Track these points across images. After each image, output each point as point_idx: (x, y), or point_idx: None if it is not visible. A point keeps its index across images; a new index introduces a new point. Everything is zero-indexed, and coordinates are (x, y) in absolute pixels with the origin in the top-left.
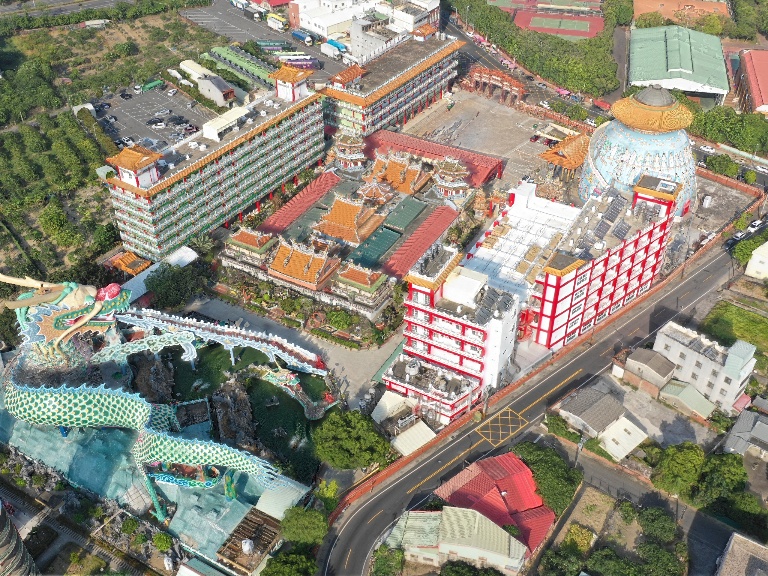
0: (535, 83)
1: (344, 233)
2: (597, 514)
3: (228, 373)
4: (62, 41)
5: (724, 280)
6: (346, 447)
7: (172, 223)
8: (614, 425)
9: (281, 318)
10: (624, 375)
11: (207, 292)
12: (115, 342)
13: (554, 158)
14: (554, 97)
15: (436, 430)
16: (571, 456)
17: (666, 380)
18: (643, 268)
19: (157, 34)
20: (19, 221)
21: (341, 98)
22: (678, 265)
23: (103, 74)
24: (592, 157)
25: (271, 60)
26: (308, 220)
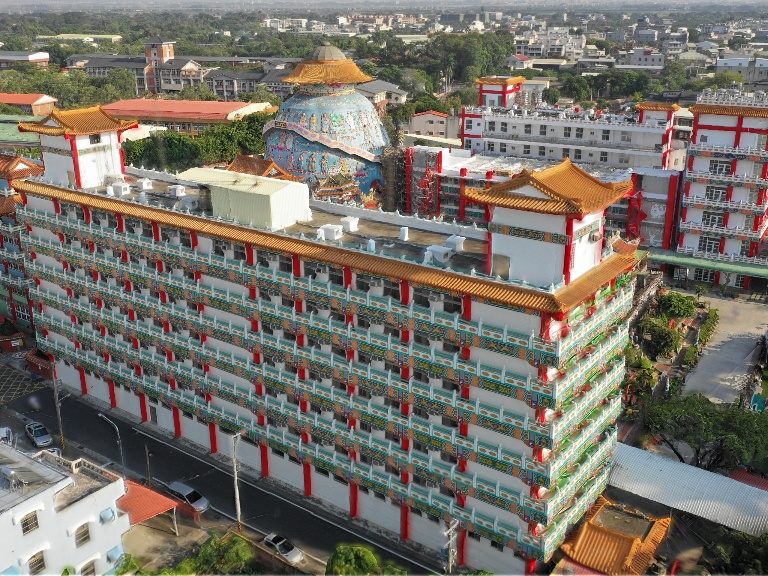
0: None
1: None
2: None
3: None
4: None
5: None
6: None
7: None
8: None
9: (678, 368)
10: None
11: (643, 443)
12: None
13: None
14: None
15: None
16: None
17: None
18: None
19: None
20: None
21: None
22: None
23: None
24: None
25: None
26: None
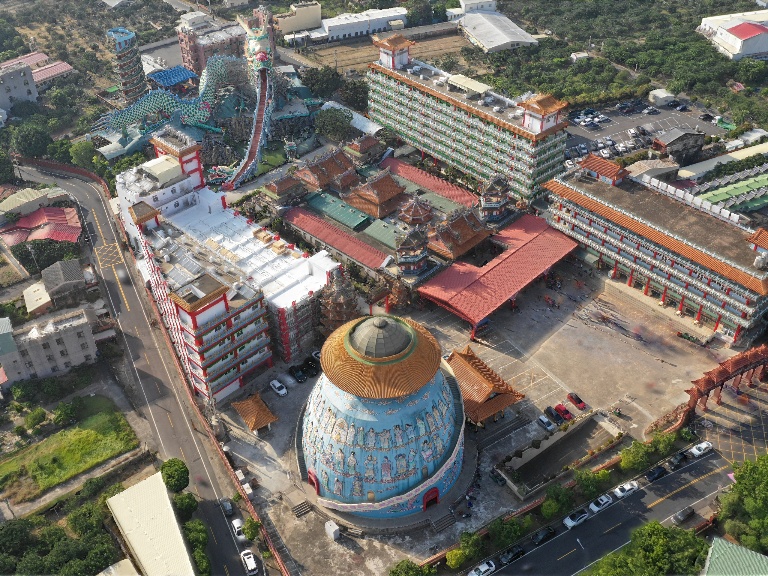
0: None
1: None
2: (3, 275)
3: None
4: None
5: None
6: None
7: None
8: None
9: None
10: None
11: None
12: None
13: None
14: None
15: None
16: None
17: None
18: None
19: None
20: None
21: None
22: None
23: None
24: None
25: None
26: None
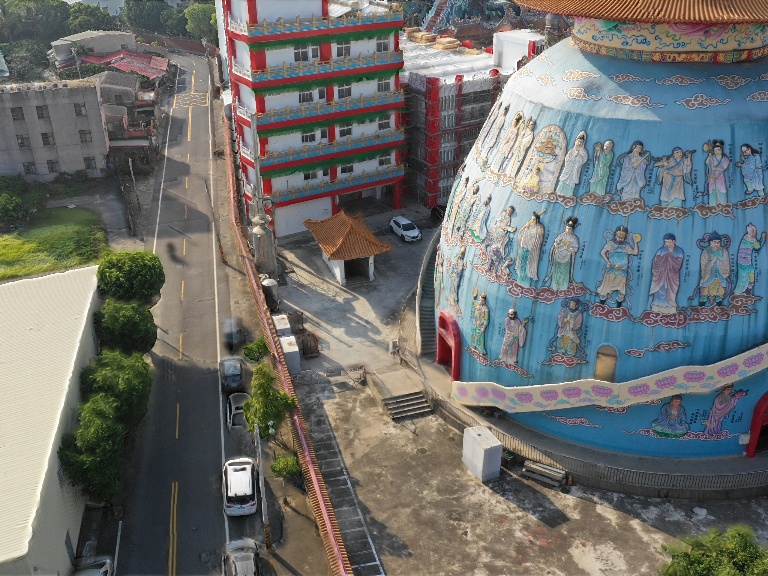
0: None
1: None
2: None
3: None
4: None
5: None
6: None
7: None
8: None
9: None
10: None
11: None
12: None
13: None
14: None
15: None
16: None
17: None
18: None
19: None
20: None
21: None
22: None
23: None
24: None
25: None
26: None
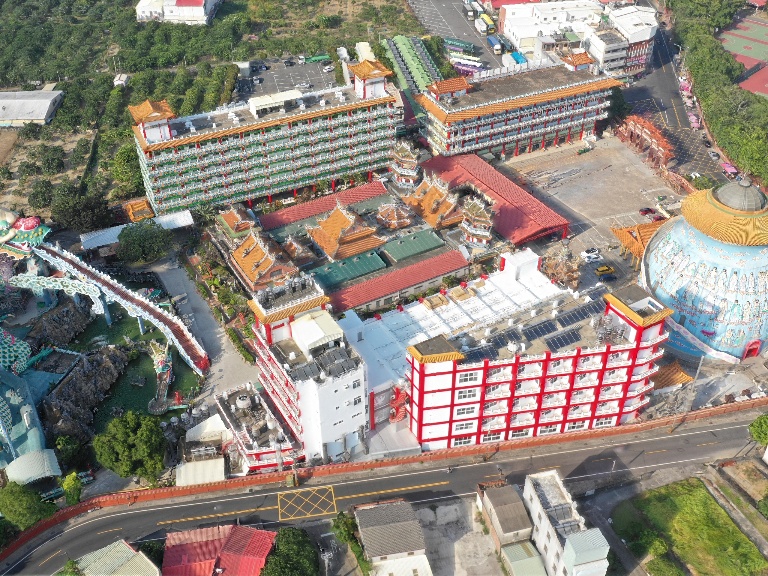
0: (709, 151)
1: (328, 244)
2: None
3: (128, 339)
4: (287, 3)
5: (726, 455)
6: (116, 449)
7: (175, 184)
8: (405, 558)
9: (216, 307)
10: (482, 510)
11: (180, 259)
12: (32, 272)
13: (626, 237)
14: (717, 172)
15: (232, 474)
16: (344, 569)
17: (514, 537)
18: (596, 396)
19: (367, 13)
20: (103, 148)
21: (428, 108)
22: (679, 413)
23: (284, 39)
24: (650, 248)
25: (444, 60)
26: (315, 221)
